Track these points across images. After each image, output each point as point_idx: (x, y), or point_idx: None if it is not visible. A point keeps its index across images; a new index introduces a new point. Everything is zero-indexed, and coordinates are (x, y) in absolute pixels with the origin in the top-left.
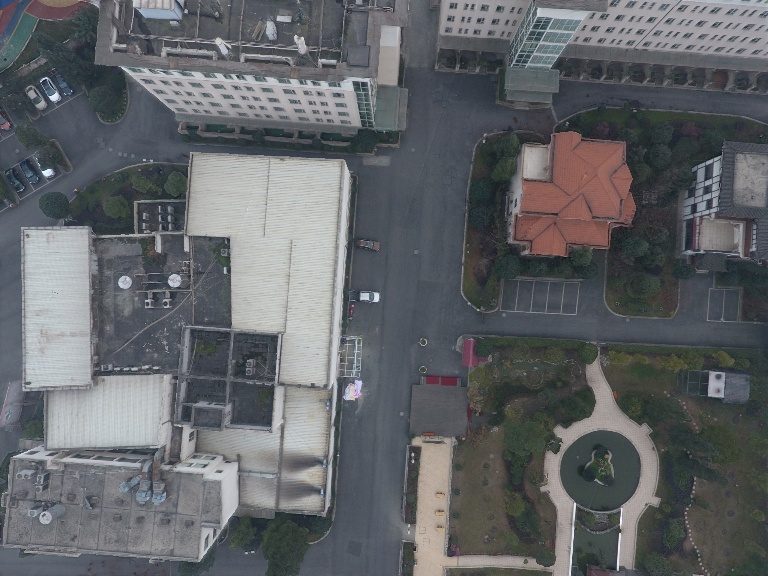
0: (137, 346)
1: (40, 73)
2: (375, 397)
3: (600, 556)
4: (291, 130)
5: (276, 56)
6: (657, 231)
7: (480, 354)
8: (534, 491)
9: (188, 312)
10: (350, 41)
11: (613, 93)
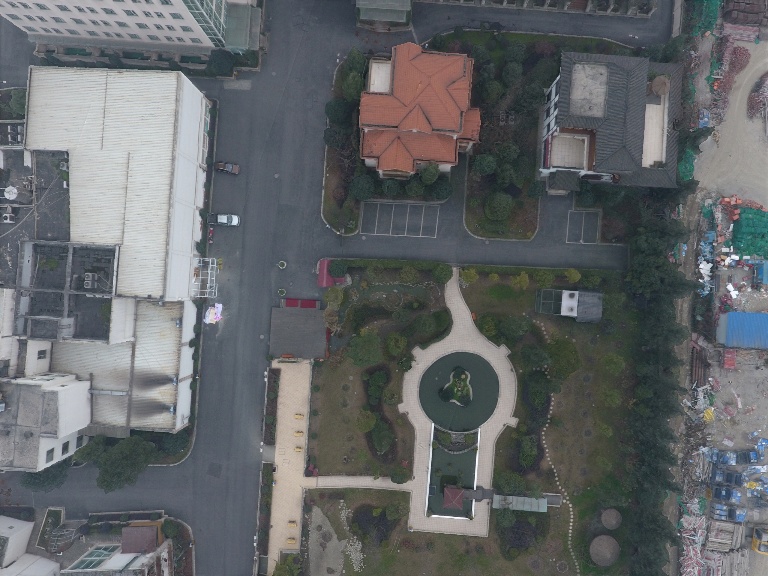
0: None
1: None
2: (235, 320)
3: (458, 476)
4: None
5: None
6: (506, 148)
7: (333, 273)
8: (393, 412)
9: (31, 227)
10: None
11: (474, 15)
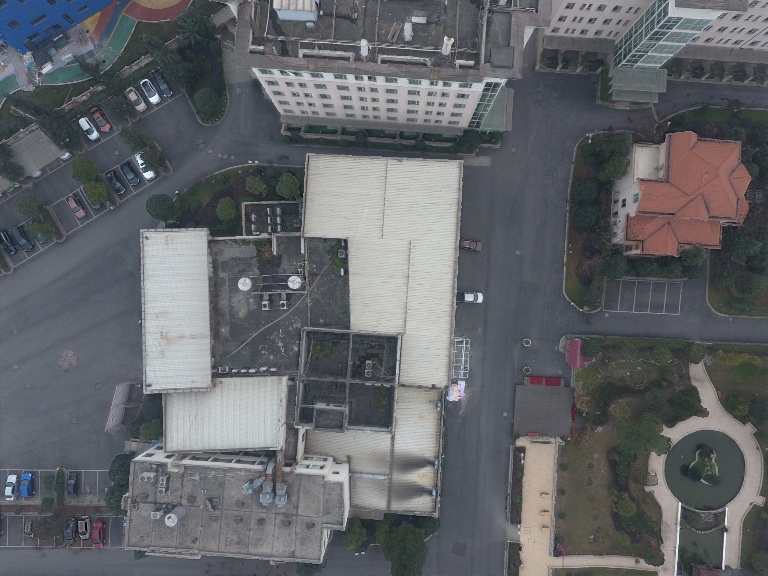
0: (253, 348)
1: (140, 75)
2: (478, 398)
3: (705, 555)
4: (393, 131)
5: (414, 57)
6: (767, 230)
7: (588, 354)
8: (639, 491)
9: (303, 314)
10: (492, 42)
11: (714, 92)
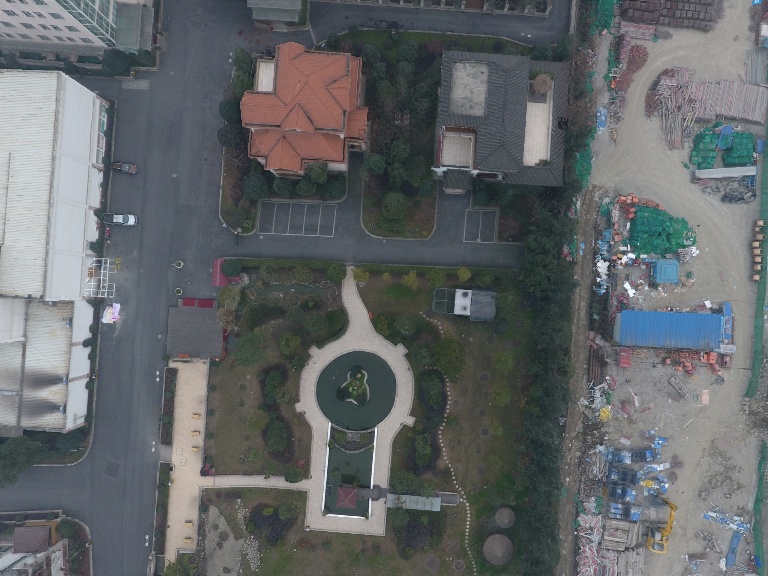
0: None
1: None
2: (133, 320)
3: None
4: None
5: None
6: (395, 147)
7: (225, 273)
8: (290, 411)
9: None
10: None
11: (372, 14)
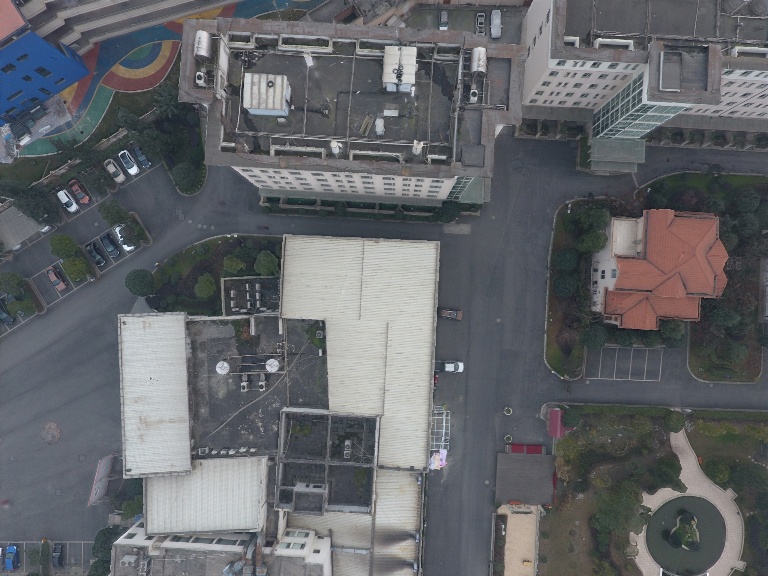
0: (232, 428)
1: (118, 146)
2: (460, 466)
3: None
4: None
5: (386, 153)
6: (746, 302)
7: (568, 425)
8: (620, 557)
9: (282, 393)
10: (463, 139)
11: (694, 157)
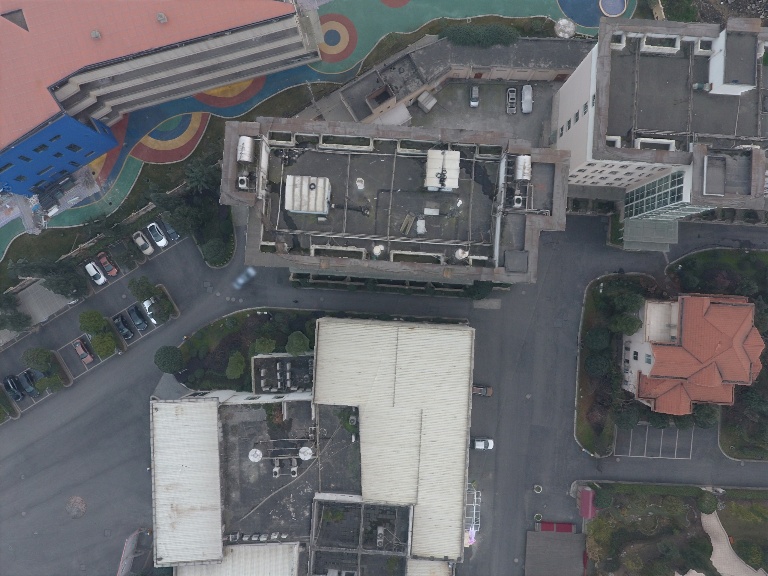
0: (263, 513)
1: (147, 219)
2: (489, 544)
3: None
4: None
5: (427, 253)
6: None
7: (600, 507)
8: None
9: (314, 478)
10: (506, 243)
11: (724, 234)
